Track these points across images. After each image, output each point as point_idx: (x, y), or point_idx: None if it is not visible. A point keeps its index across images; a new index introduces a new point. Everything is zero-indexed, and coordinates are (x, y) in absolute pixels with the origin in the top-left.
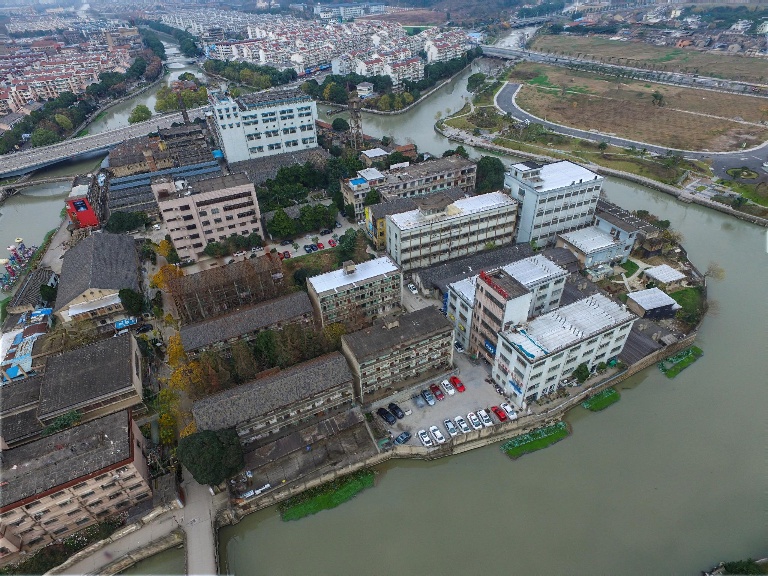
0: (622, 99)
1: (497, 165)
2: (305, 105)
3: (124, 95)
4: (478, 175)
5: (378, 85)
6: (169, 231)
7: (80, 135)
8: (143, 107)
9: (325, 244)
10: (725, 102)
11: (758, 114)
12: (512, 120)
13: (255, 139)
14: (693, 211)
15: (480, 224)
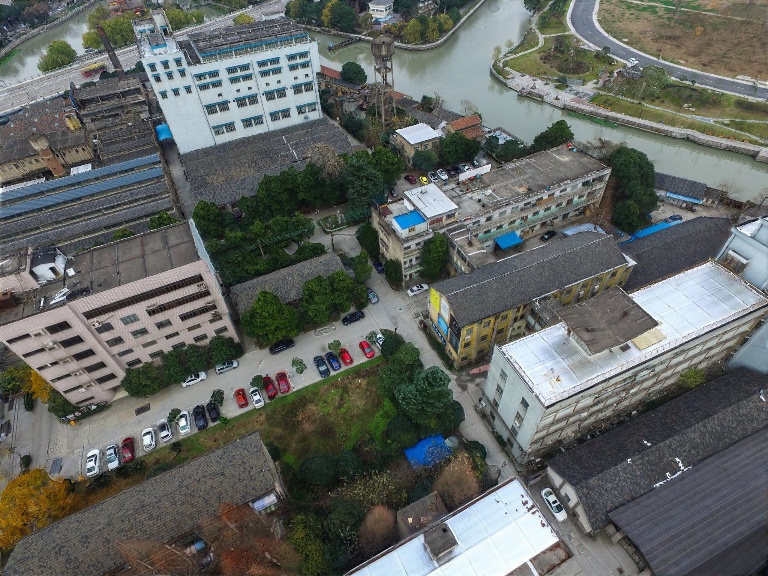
0: (758, 19)
1: (647, 168)
2: (299, 49)
3: (46, 21)
4: (609, 185)
5: (400, 2)
6: (35, 370)
7: None
8: (61, 44)
9: (353, 350)
10: None
11: None
12: (610, 60)
13: (220, 111)
14: None
15: (690, 351)
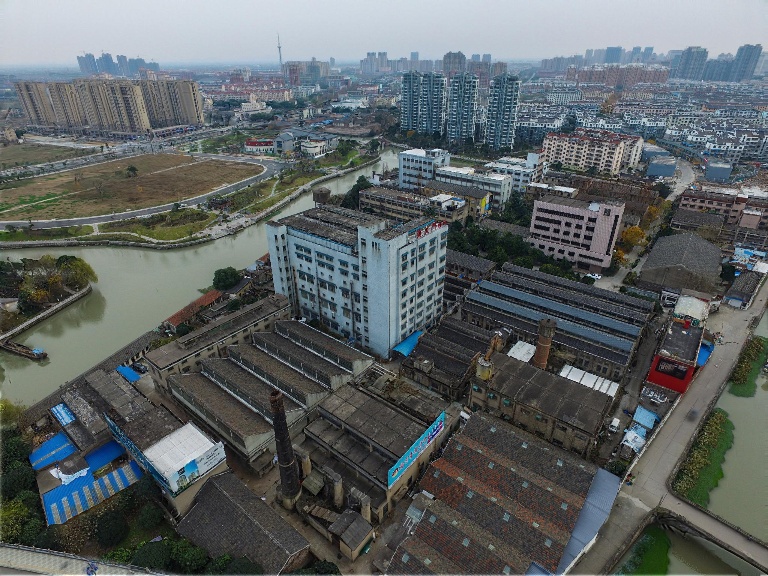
0: (103, 184)
1: None
2: None
3: None
4: None
5: None
6: None
7: None
8: None
9: None
10: (136, 164)
11: (175, 160)
12: (184, 209)
13: None
14: (343, 179)
15: None
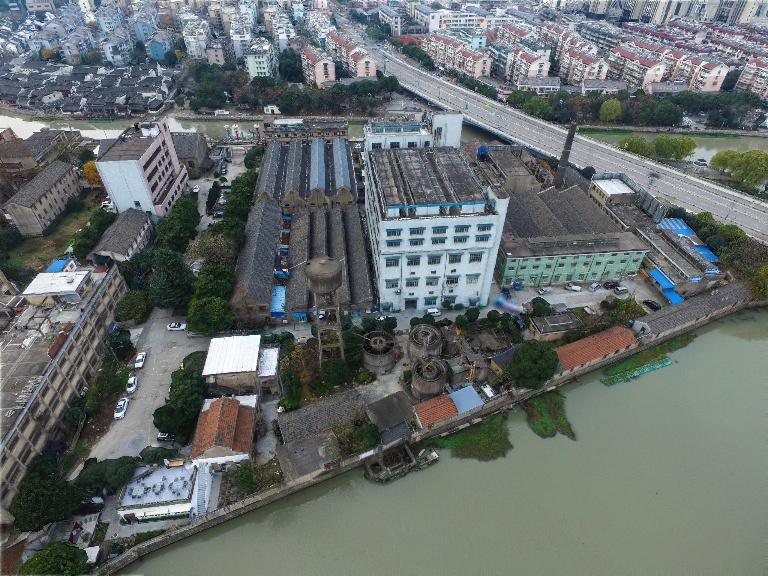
0: None
1: None
2: None
3: None
4: None
5: None
6: None
7: (610, 132)
8: (682, 141)
9: None
10: None
11: None
12: None
13: None
14: None
15: None
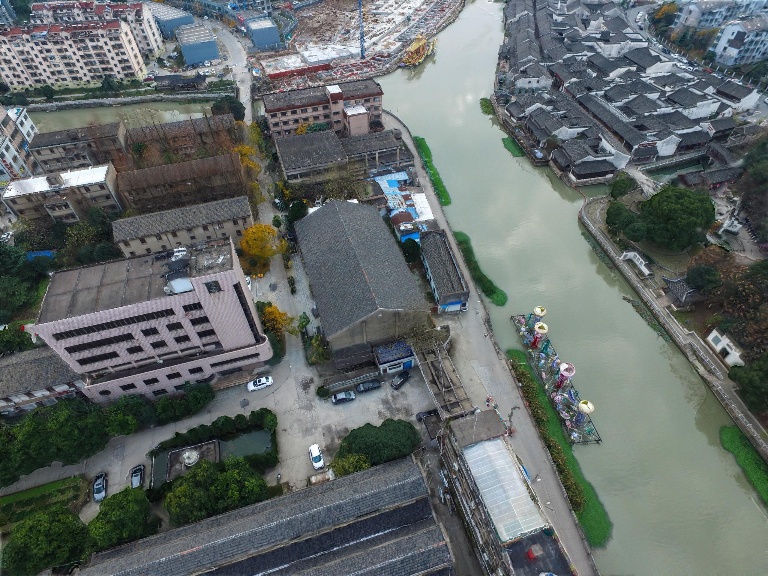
0: None
1: None
2: None
3: None
4: None
5: None
6: None
7: None
8: None
9: None
10: None
11: None
12: None
13: None
14: None
15: None
